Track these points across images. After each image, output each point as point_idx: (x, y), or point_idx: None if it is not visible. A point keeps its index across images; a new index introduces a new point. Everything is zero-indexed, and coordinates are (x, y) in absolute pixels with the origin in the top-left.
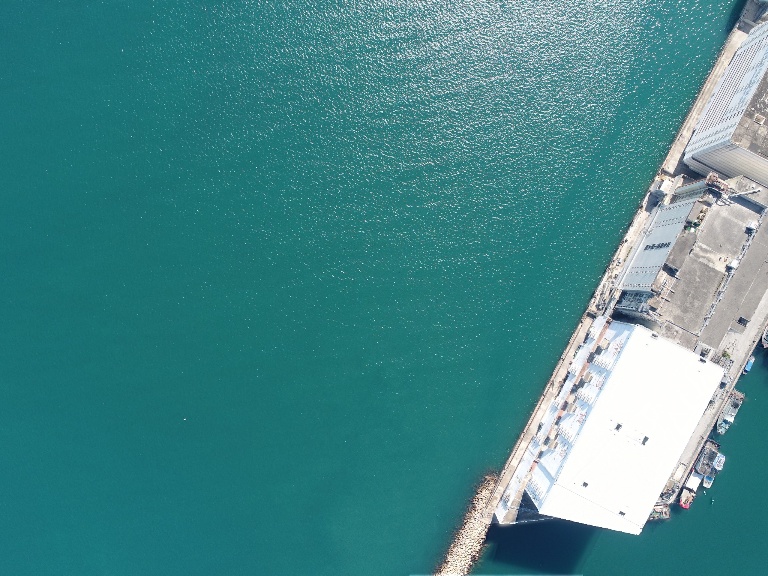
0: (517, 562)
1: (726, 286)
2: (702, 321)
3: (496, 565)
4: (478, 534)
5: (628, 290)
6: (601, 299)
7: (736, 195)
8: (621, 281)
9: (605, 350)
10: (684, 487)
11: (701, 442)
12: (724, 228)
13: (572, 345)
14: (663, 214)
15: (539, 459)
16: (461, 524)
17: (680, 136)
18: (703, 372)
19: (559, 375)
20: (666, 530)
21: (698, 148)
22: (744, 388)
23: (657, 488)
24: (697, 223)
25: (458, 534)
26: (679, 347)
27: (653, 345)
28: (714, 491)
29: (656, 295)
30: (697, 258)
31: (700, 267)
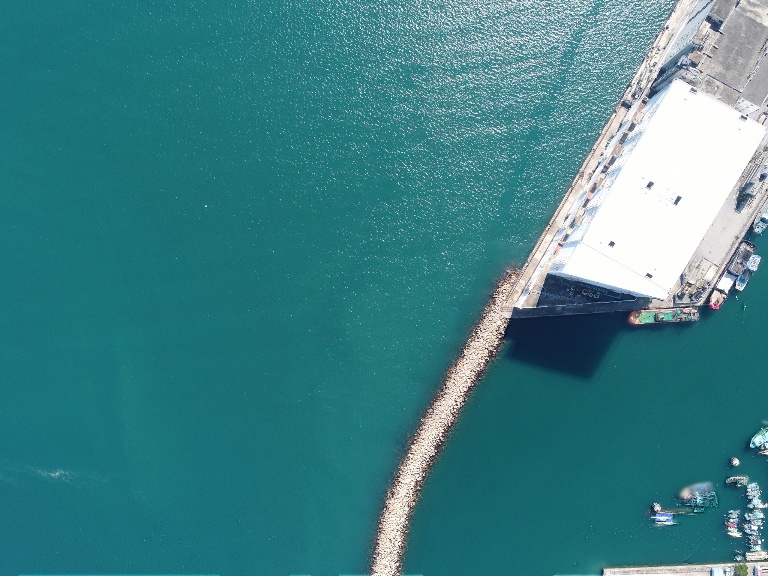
0: (535, 362)
1: None
2: (745, 79)
3: (514, 363)
4: (497, 328)
5: (667, 63)
6: (637, 87)
7: None
8: (660, 62)
9: (640, 123)
10: (715, 289)
11: (736, 242)
12: None
13: (604, 136)
14: None
15: (564, 242)
16: (480, 319)
17: None
18: (744, 130)
19: (589, 167)
20: (693, 335)
21: None
22: None
23: (688, 251)
24: None
25: (476, 328)
26: (719, 103)
27: (692, 100)
28: (747, 295)
29: (697, 51)
30: (744, 12)
31: (746, 22)
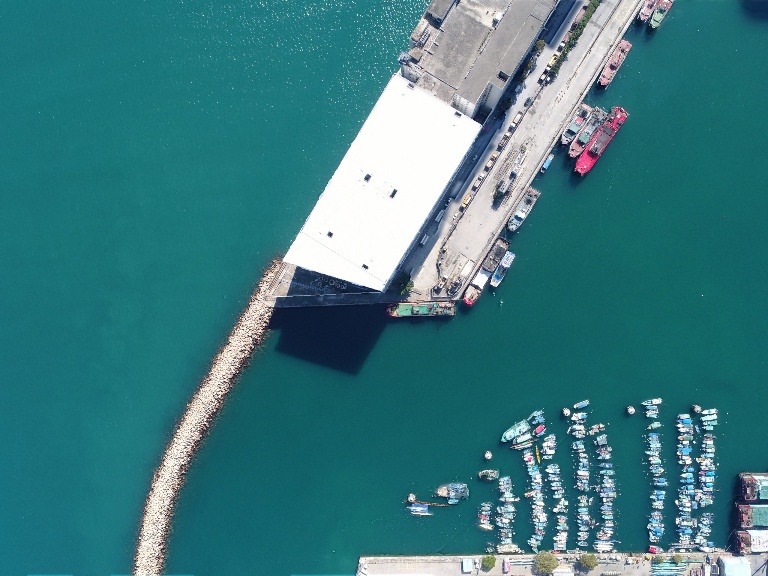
0: (300, 351)
1: (488, 38)
2: None
3: (278, 351)
4: (260, 316)
5: None
6: None
7: None
8: None
9: None
10: (471, 284)
11: (491, 238)
12: None
13: None
14: None
15: None
16: (246, 307)
17: None
18: (459, 127)
19: None
20: (451, 329)
21: None
22: (542, 188)
23: (403, 244)
24: None
25: (242, 316)
26: (435, 99)
27: (409, 95)
28: (502, 291)
29: (419, 47)
30: (464, 11)
31: (466, 20)
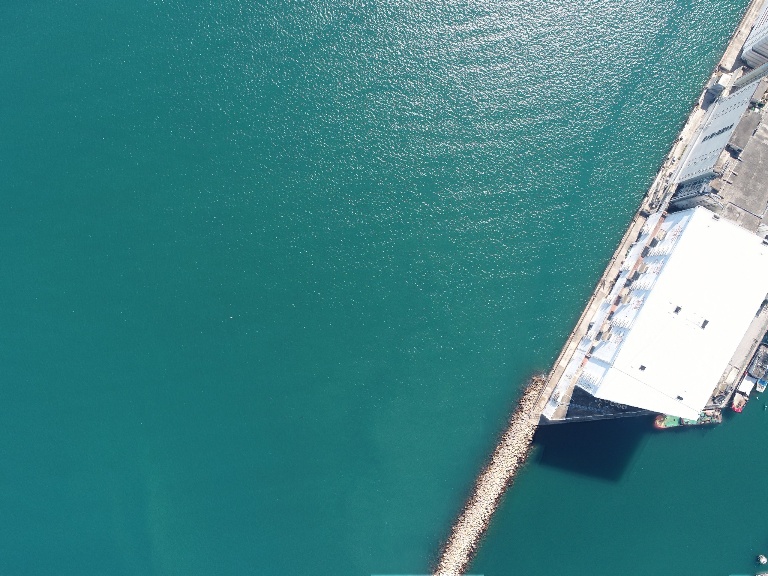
0: (564, 466)
1: None
2: (765, 204)
3: (542, 468)
4: (525, 435)
5: (686, 181)
6: (655, 197)
7: None
8: (677, 176)
9: (661, 240)
10: (736, 391)
11: (755, 345)
12: None
13: (624, 244)
14: (722, 105)
15: (591, 354)
16: (507, 426)
17: (738, 33)
18: (766, 255)
19: (610, 275)
20: (717, 435)
21: (759, 38)
22: None
23: (716, 373)
24: (762, 103)
25: (504, 435)
26: (741, 229)
27: (714, 227)
28: (767, 396)
29: (718, 177)
30: (761, 140)
31: (764, 149)
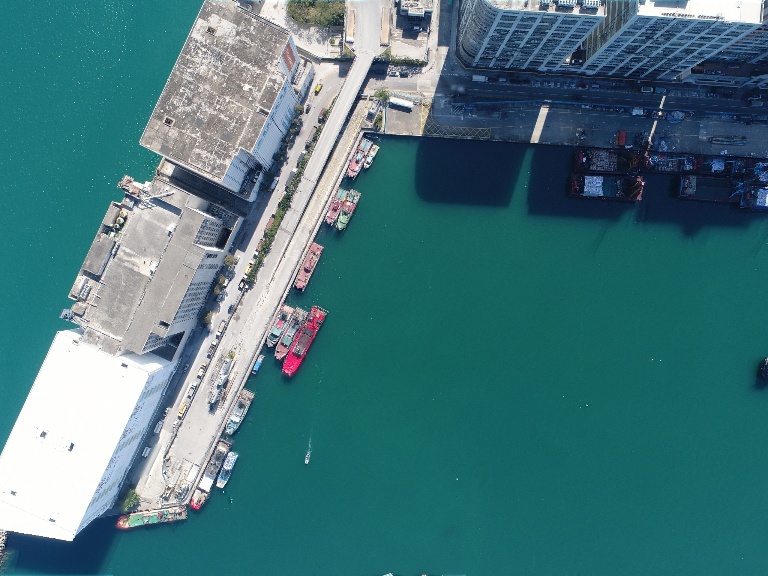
0: (41, 568)
1: None
2: None
3: (18, 572)
4: None
5: None
6: None
7: (149, 198)
8: None
9: None
10: (198, 488)
11: (211, 443)
12: (147, 232)
13: None
14: None
15: None
16: None
17: None
18: (127, 377)
19: None
20: (186, 531)
21: None
22: (257, 387)
23: (87, 494)
24: (115, 227)
25: None
26: (101, 353)
27: (75, 351)
28: (230, 490)
29: (82, 301)
30: (122, 262)
31: (125, 271)
